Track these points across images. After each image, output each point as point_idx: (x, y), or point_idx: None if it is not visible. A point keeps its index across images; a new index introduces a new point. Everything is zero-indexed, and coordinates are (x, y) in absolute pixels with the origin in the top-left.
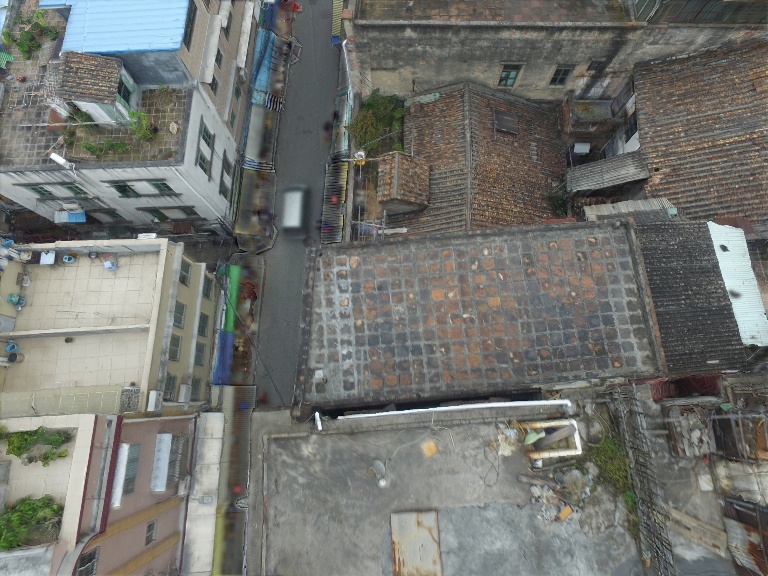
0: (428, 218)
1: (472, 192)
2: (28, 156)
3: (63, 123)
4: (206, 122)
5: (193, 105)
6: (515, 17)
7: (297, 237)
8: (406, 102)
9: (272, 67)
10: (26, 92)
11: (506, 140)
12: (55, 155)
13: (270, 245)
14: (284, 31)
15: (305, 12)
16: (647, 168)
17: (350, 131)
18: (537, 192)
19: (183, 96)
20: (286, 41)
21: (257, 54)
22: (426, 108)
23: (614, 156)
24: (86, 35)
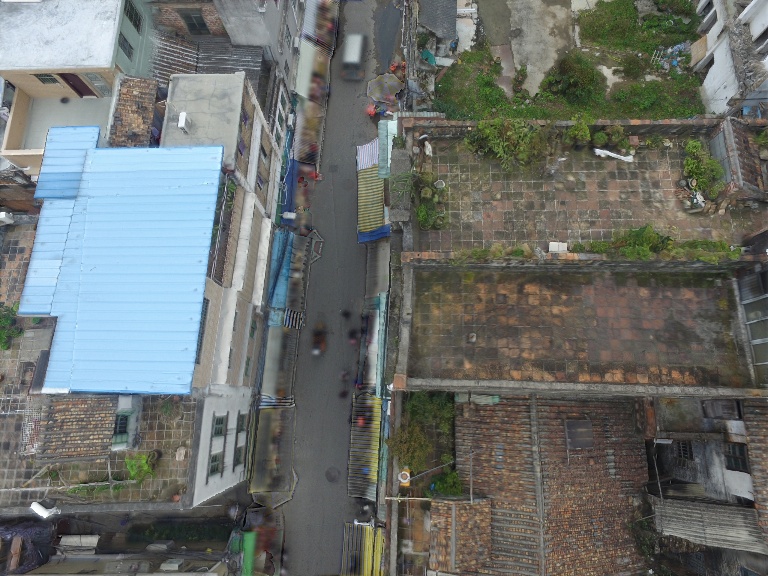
0: (490, 572)
1: (546, 552)
2: (5, 487)
3: (45, 487)
4: (218, 412)
5: (204, 417)
6: (602, 354)
7: (319, 467)
8: (457, 397)
9: (291, 274)
10: (4, 395)
11: (580, 458)
12: (36, 505)
13: (289, 497)
14: (303, 224)
15: (325, 181)
16: (767, 546)
17: (392, 448)
18: (618, 521)
19: (192, 406)
20: (306, 239)
21: (274, 262)
22: (482, 412)
23: (718, 505)
24: (74, 363)
